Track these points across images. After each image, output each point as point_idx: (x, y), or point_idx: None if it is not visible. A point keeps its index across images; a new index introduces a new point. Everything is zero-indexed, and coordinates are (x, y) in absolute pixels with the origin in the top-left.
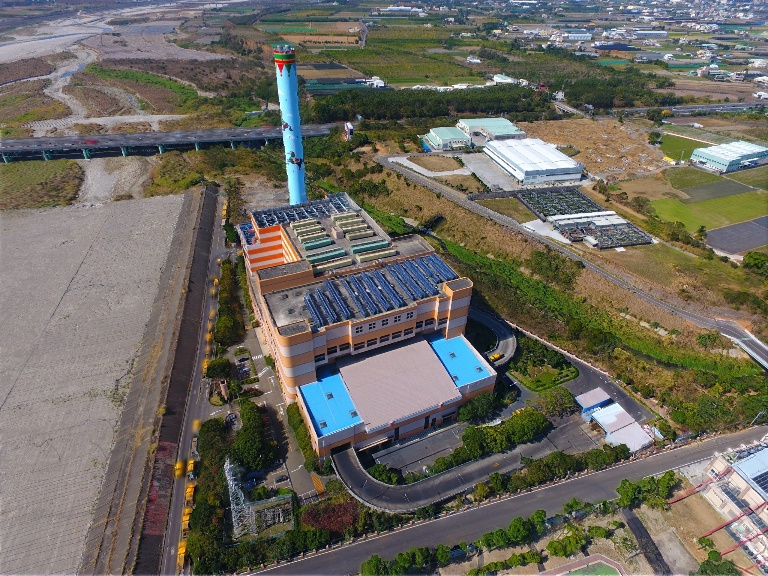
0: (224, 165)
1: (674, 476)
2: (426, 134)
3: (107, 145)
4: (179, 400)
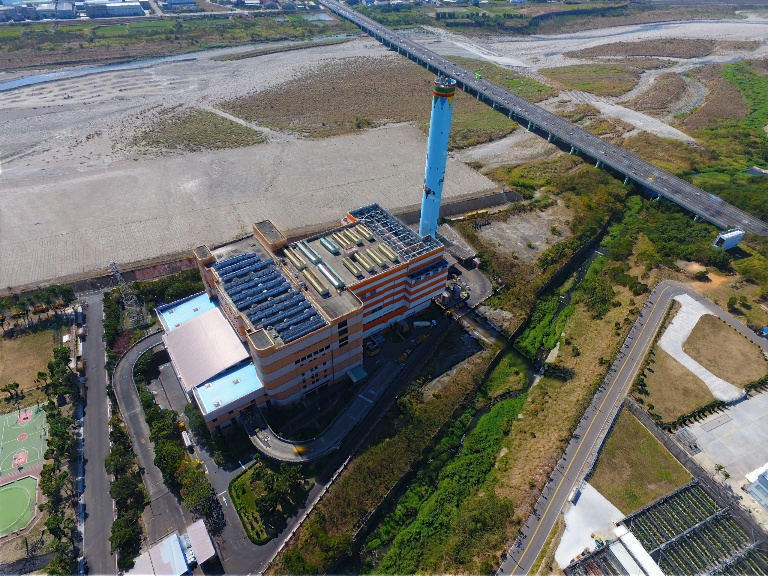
0: (573, 189)
1: None
2: None
3: (543, 126)
4: None
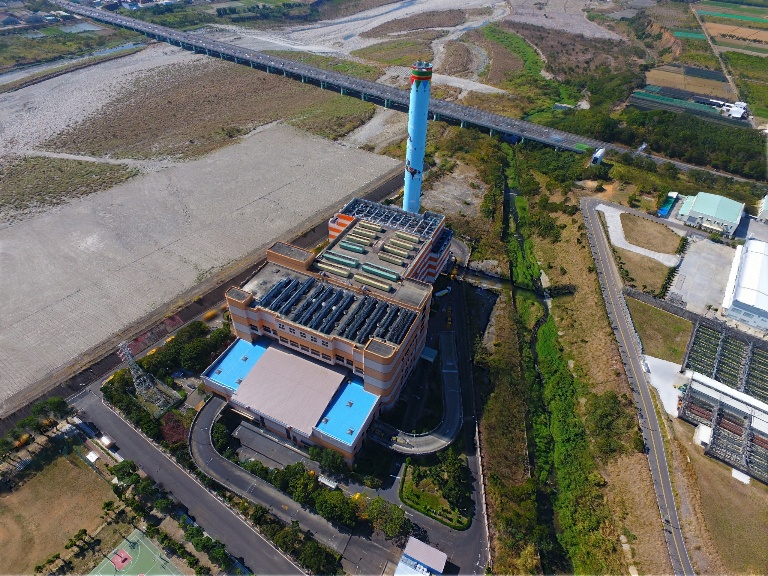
0: (460, 149)
1: None
2: (689, 196)
3: (401, 101)
4: (214, 300)
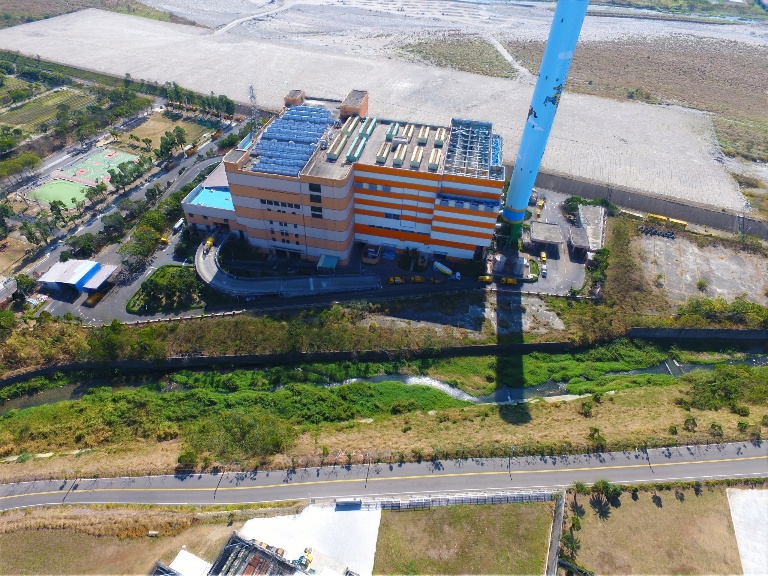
0: None
1: (20, 273)
2: None
3: None
4: None
